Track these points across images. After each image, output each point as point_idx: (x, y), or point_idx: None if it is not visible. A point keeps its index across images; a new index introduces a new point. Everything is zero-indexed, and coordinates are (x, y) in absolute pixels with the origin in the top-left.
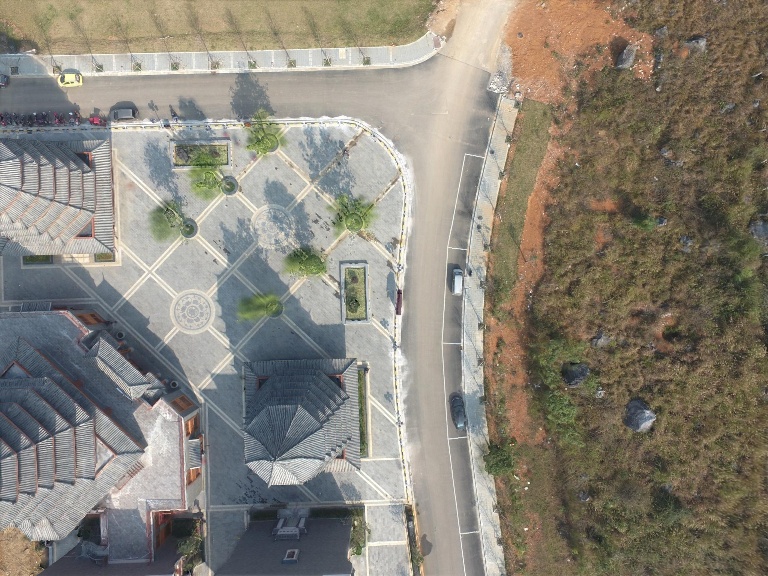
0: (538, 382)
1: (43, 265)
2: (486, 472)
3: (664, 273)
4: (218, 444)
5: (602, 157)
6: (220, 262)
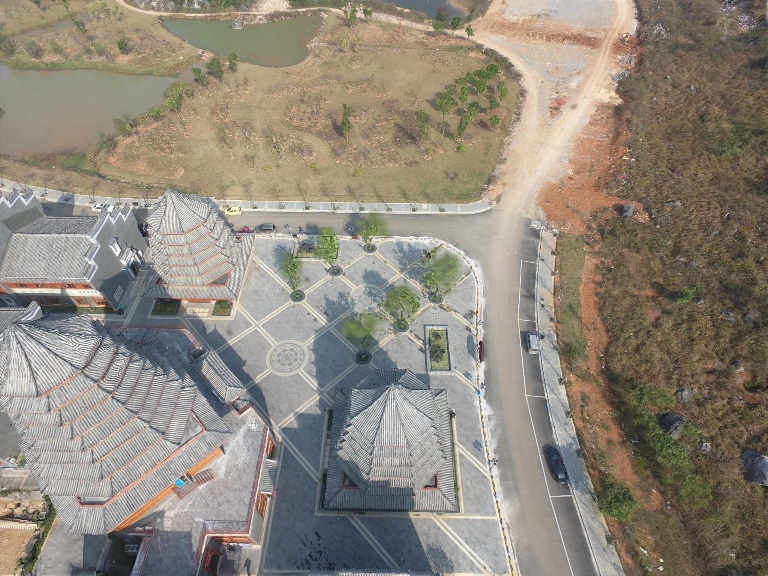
0: (634, 437)
1: (167, 316)
2: (604, 541)
3: (720, 336)
4: (288, 488)
5: (631, 263)
6: (319, 321)
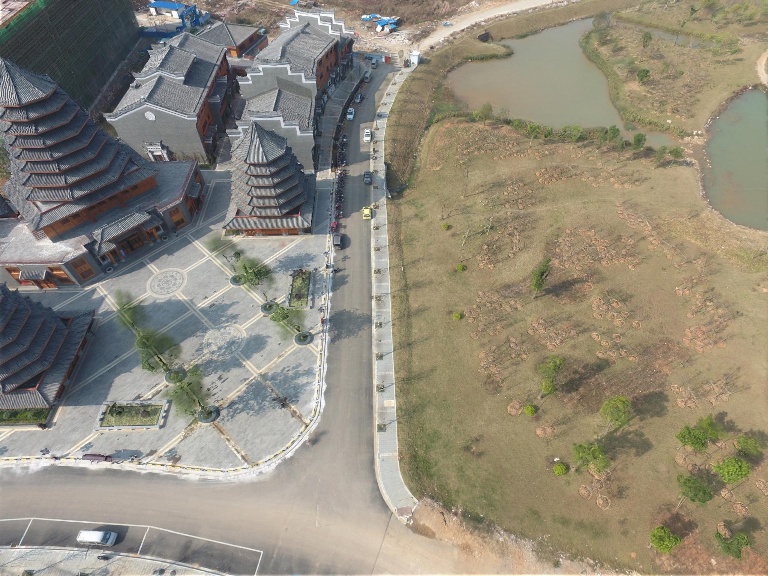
0: None
1: None
2: None
3: None
4: (42, 299)
5: None
6: (204, 301)
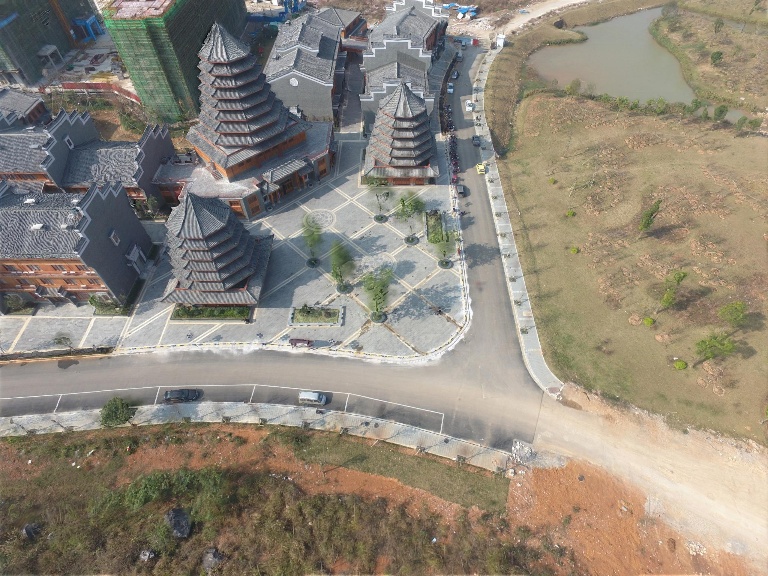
0: None
1: (362, 156)
2: None
3: None
4: None
5: None
6: (354, 234)
